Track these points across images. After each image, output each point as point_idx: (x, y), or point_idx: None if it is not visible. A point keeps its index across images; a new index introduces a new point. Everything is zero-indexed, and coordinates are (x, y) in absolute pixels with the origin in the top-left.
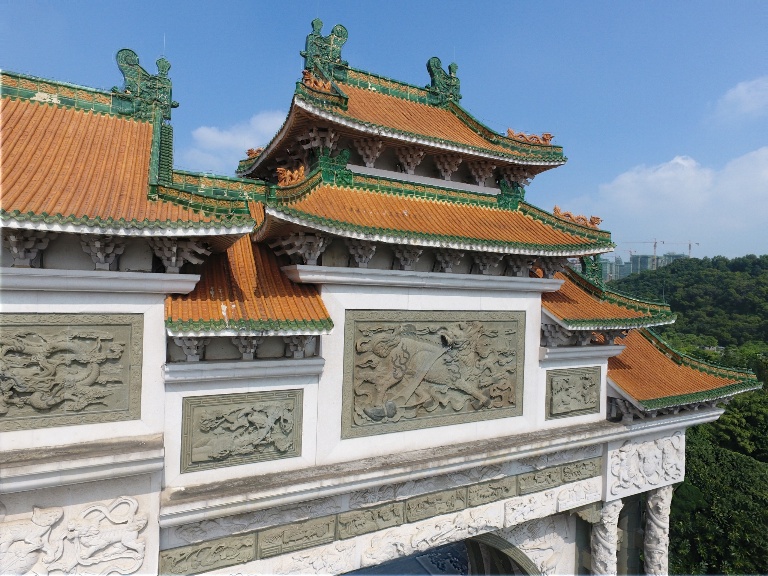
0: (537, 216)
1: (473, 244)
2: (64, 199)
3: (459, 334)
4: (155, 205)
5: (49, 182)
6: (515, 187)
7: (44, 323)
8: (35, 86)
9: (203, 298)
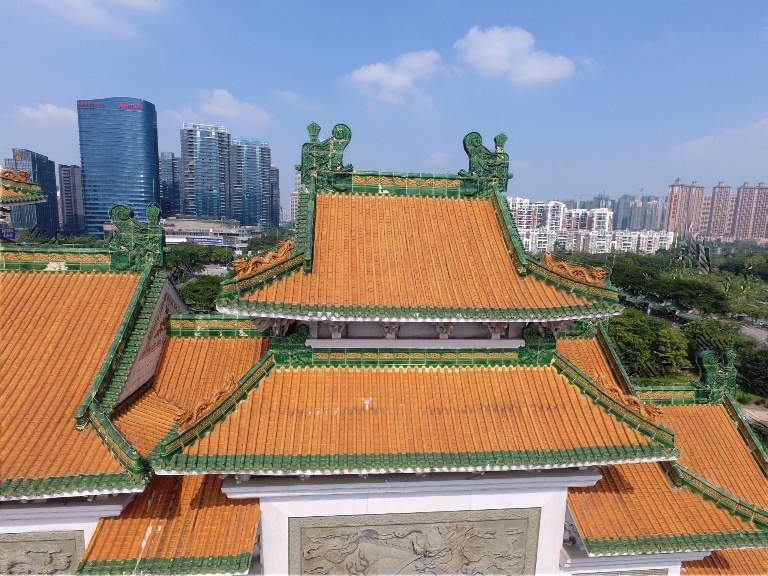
0: (574, 380)
1: (434, 467)
2: (3, 441)
3: (433, 542)
4: (82, 436)
5: (6, 409)
6: (548, 335)
7: (4, 540)
8: (47, 257)
9: (136, 514)
